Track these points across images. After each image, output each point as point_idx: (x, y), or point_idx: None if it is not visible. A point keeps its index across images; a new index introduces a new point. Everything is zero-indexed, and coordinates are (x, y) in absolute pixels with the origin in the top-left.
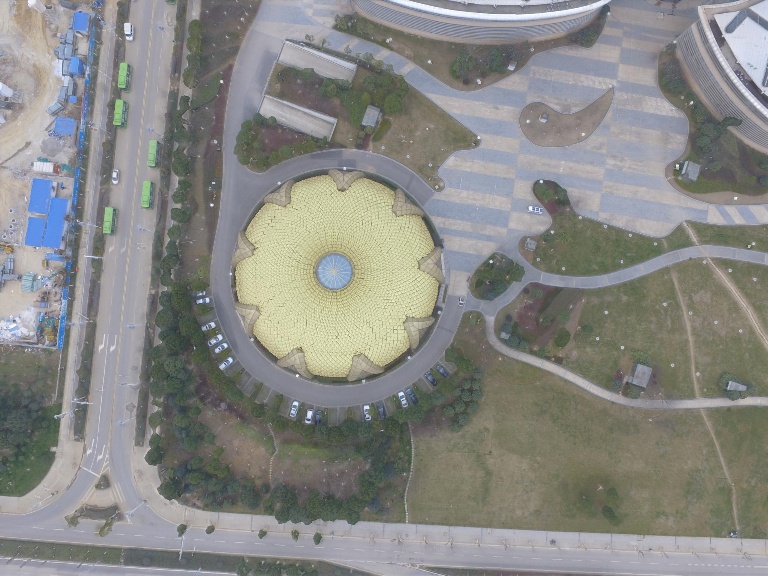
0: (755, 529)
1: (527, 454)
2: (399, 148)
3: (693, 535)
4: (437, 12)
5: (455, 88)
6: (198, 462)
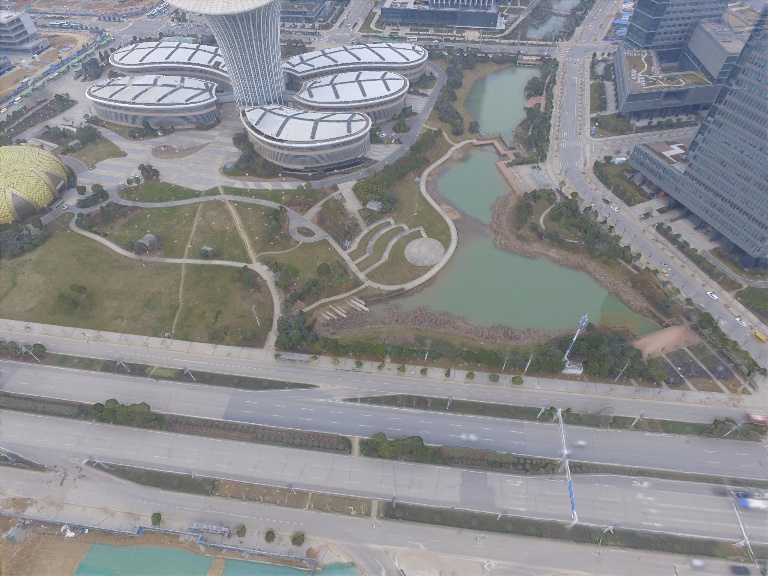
0: None
1: (47, 274)
2: (82, 155)
3: (136, 334)
4: (117, 105)
5: (128, 140)
6: None
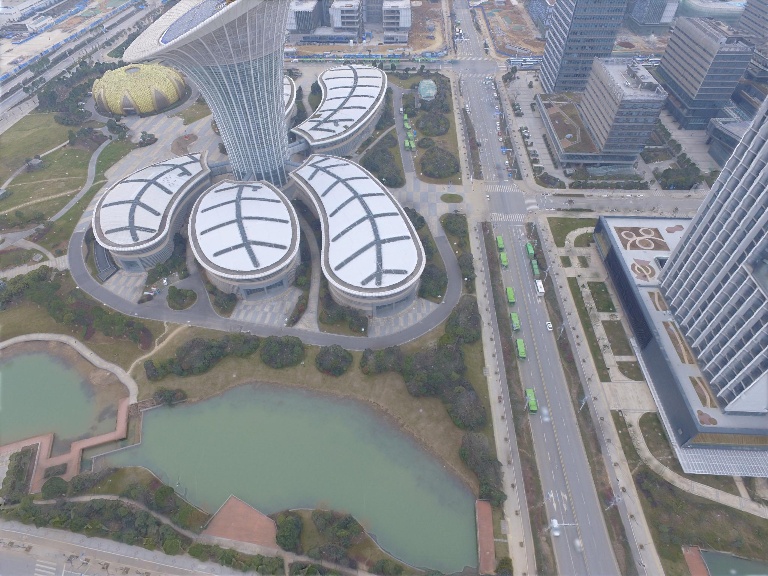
0: None
1: None
2: None
3: None
4: None
5: None
6: (89, 67)
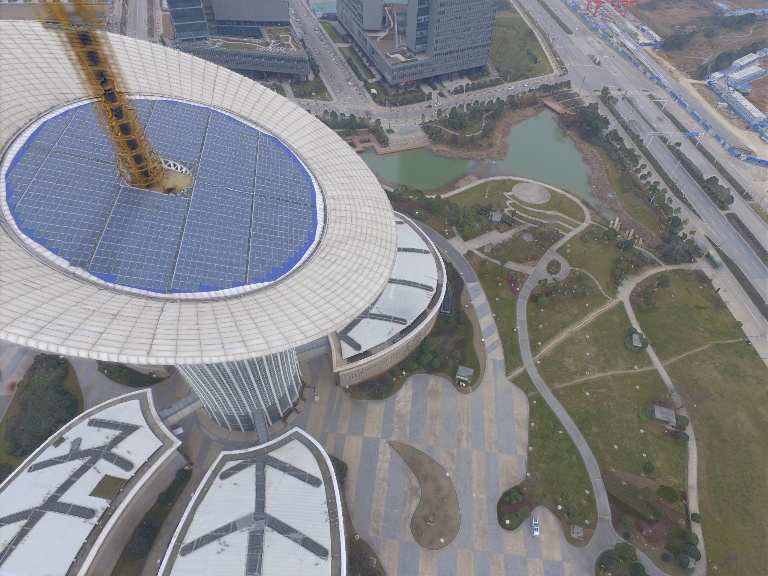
0: (735, 328)
1: None
2: None
3: None
4: None
5: None
6: None
